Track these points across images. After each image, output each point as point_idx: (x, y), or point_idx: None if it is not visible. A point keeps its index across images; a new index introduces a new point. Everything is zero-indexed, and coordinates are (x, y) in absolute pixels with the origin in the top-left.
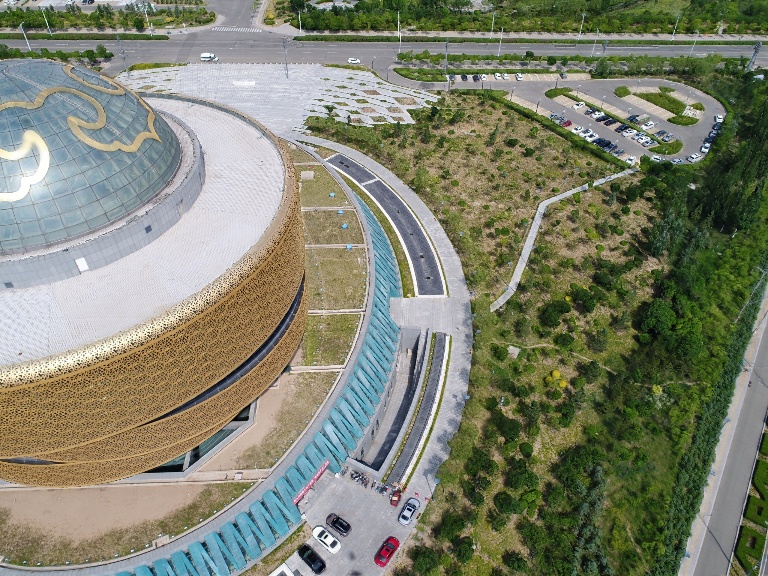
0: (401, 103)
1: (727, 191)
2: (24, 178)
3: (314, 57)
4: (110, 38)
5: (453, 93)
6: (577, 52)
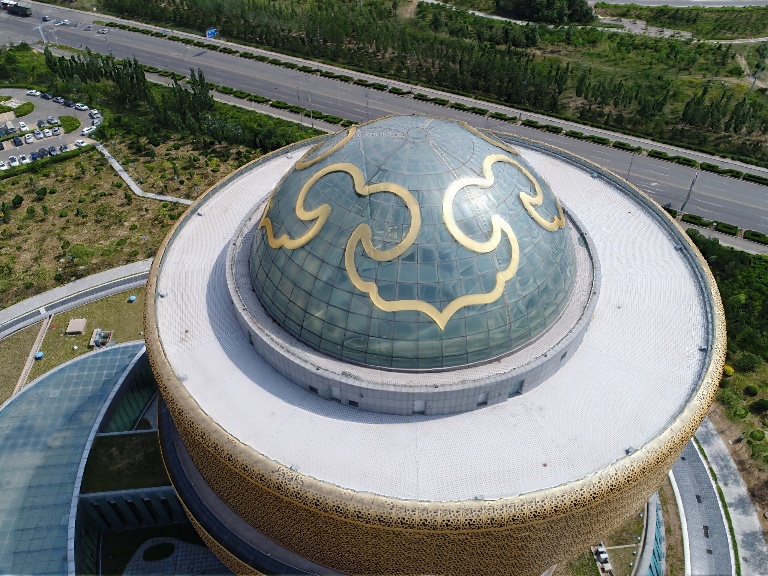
0: None
1: (185, 93)
2: None
3: None
4: None
5: None
6: None
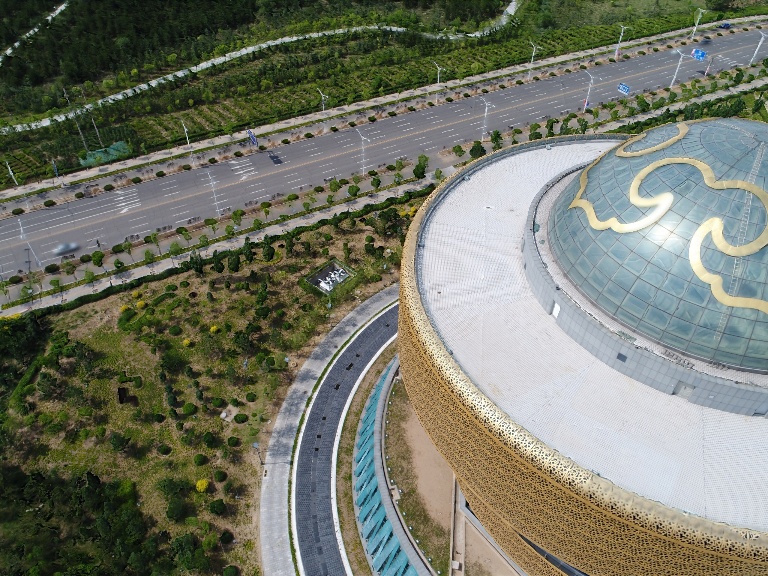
0: None
1: None
2: (615, 219)
3: None
4: None
5: None
6: None
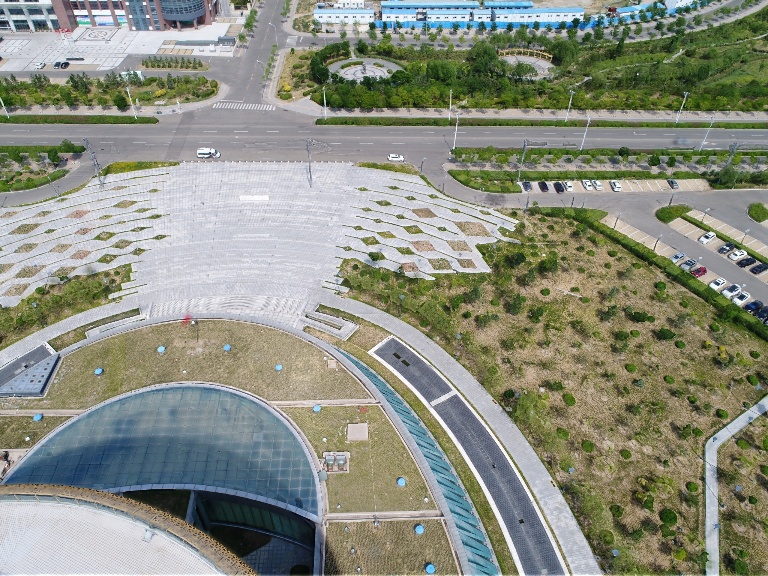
0: (466, 233)
1: None
2: None
3: (344, 151)
4: (83, 122)
5: (533, 214)
6: (678, 141)
